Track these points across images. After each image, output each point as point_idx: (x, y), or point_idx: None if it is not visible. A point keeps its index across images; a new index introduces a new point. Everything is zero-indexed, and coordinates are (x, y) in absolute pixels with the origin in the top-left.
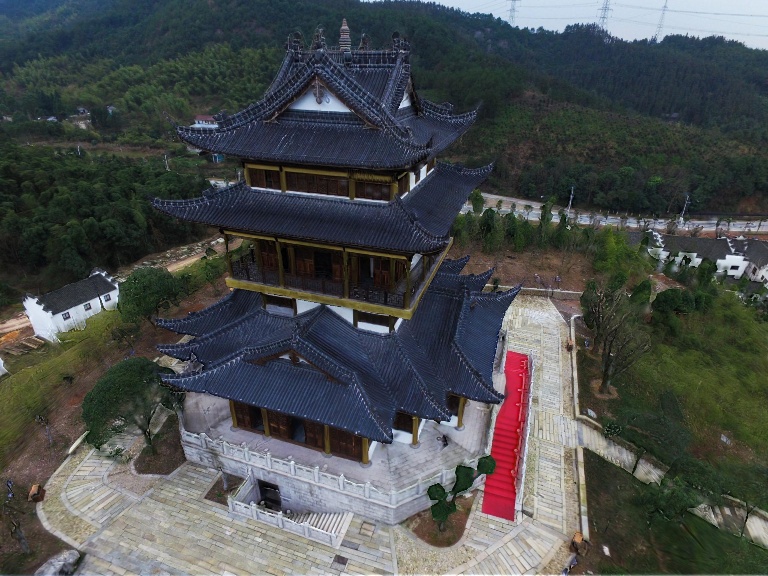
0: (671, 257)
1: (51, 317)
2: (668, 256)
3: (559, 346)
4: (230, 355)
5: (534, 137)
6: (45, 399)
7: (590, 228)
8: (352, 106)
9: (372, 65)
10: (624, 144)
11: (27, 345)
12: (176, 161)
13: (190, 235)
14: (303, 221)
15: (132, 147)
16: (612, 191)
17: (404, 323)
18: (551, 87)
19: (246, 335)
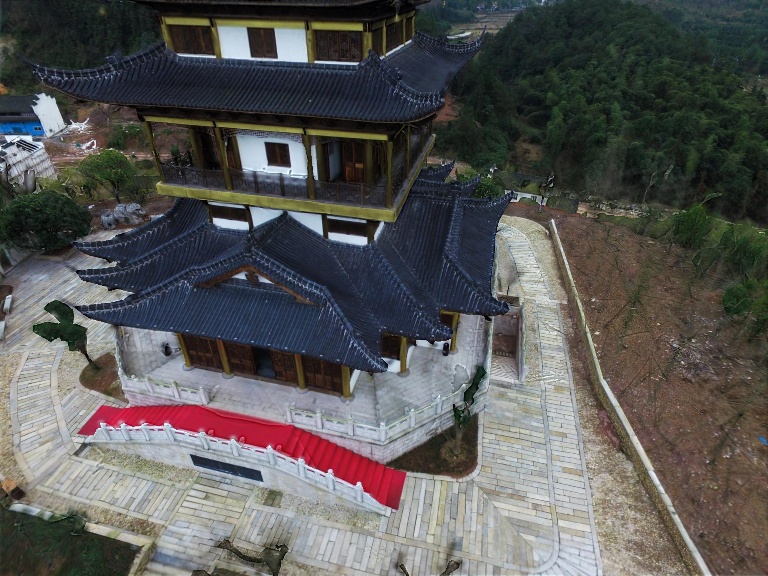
0: None
1: None
2: None
3: None
4: None
5: None
6: None
7: None
8: None
9: None
10: None
11: None
12: None
13: (744, 214)
14: None
15: None
16: None
17: (246, 236)
18: None
19: None
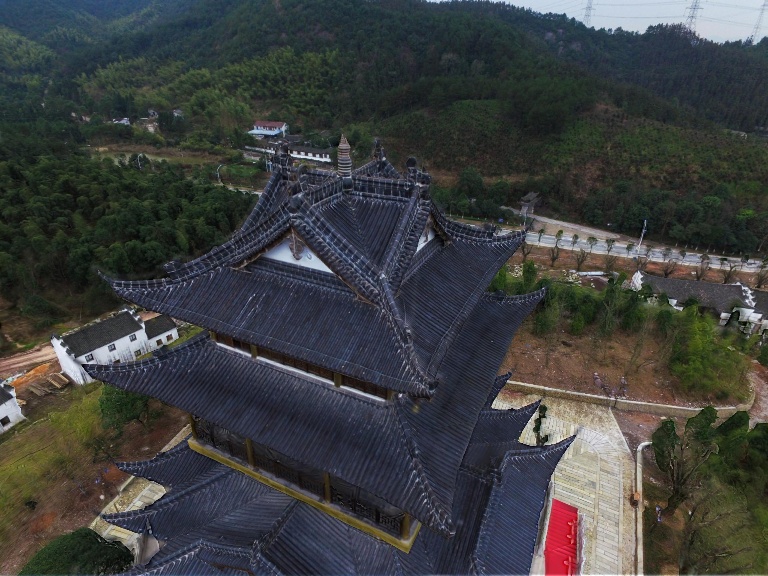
0: (764, 320)
1: (74, 360)
2: (760, 319)
3: (620, 496)
4: (181, 550)
5: (604, 156)
6: (27, 494)
7: (668, 312)
8: (339, 273)
9: (379, 195)
10: (709, 168)
11: (52, 383)
12: (231, 170)
13: None
14: (269, 414)
15: (192, 152)
16: (692, 224)
17: None
18: (627, 98)
19: (214, 502)
